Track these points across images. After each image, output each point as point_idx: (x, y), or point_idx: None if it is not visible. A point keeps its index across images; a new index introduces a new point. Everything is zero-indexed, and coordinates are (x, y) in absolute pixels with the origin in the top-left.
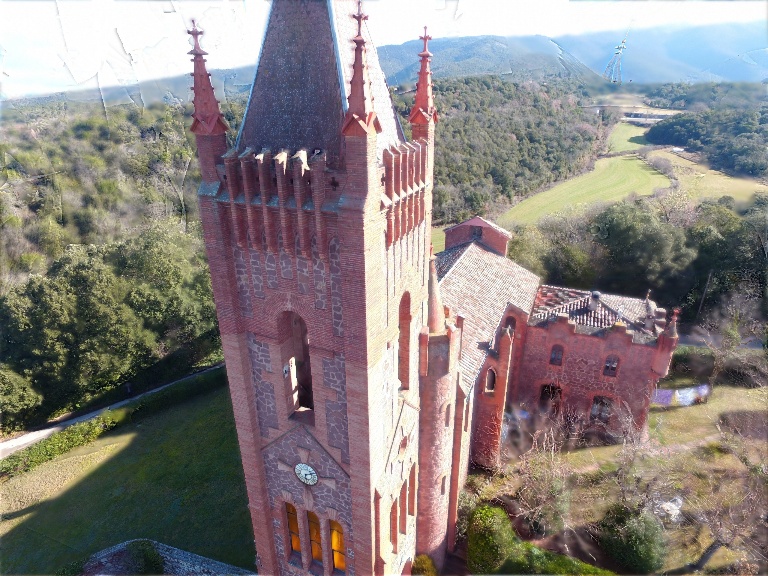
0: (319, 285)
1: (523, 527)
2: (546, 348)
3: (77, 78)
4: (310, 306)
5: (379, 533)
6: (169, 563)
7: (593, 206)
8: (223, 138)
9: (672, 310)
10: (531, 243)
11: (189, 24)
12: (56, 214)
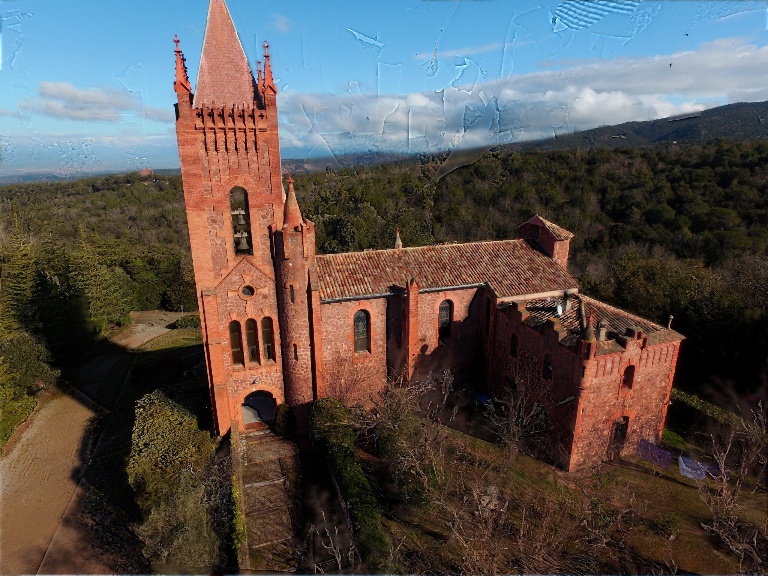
0: None
1: None
2: (508, 336)
3: (380, 115)
4: None
5: (206, 321)
6: None
7: None
8: None
9: None
10: (665, 273)
11: None
12: None
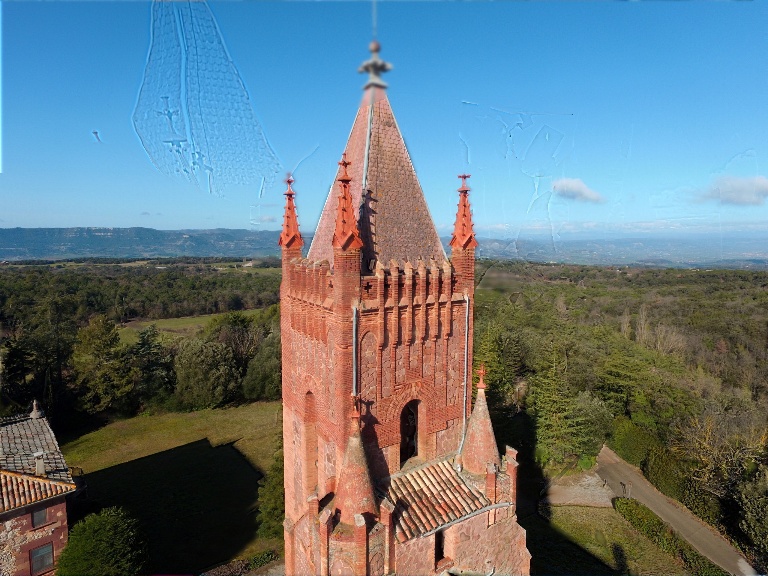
0: None
1: None
2: None
3: None
4: None
5: None
6: None
7: None
8: None
9: None
10: None
11: None
12: None
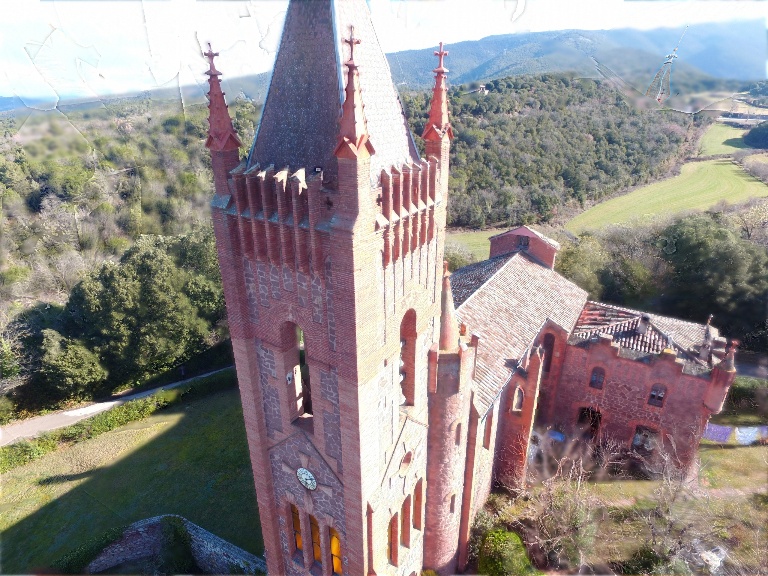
0: (316, 300)
1: (541, 556)
2: (586, 369)
3: (158, 80)
4: (308, 319)
5: (372, 546)
6: (195, 541)
7: (662, 218)
8: (236, 153)
9: (746, 337)
10: (587, 255)
11: (262, 27)
12: (138, 204)
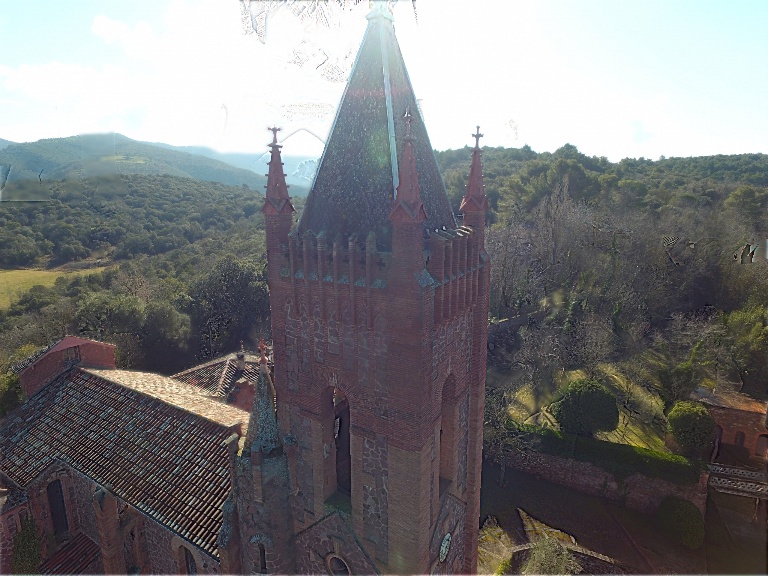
0: None
1: None
2: None
3: None
4: None
5: None
6: None
7: (63, 306)
8: None
9: None
10: None
11: None
12: None
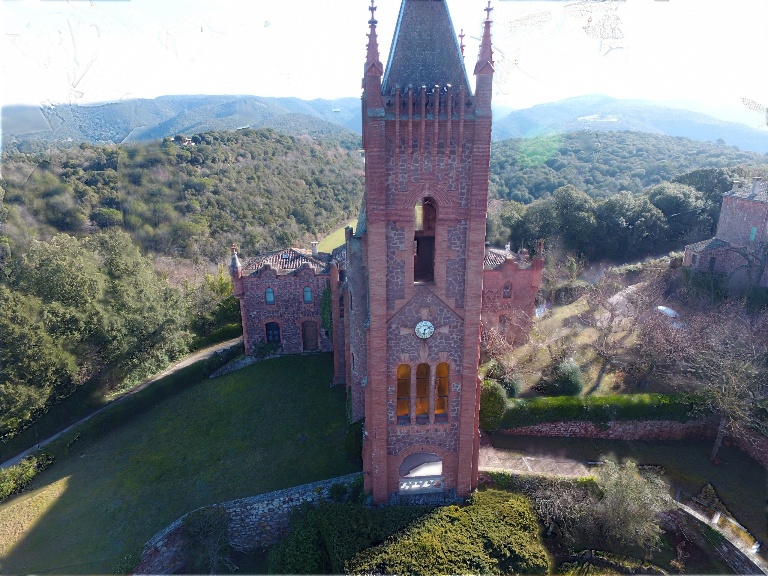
0: (451, 173)
1: None
2: None
3: None
4: (443, 190)
5: None
6: (237, 517)
7: None
8: None
9: None
10: None
11: None
12: None
